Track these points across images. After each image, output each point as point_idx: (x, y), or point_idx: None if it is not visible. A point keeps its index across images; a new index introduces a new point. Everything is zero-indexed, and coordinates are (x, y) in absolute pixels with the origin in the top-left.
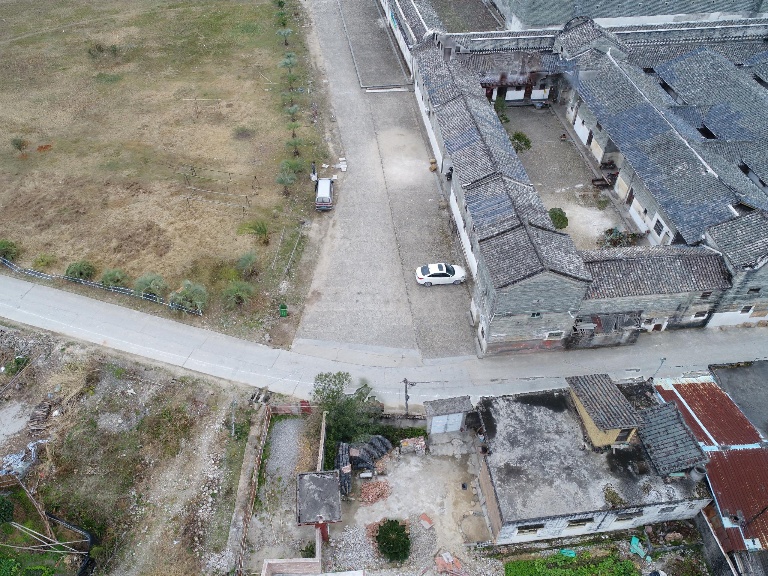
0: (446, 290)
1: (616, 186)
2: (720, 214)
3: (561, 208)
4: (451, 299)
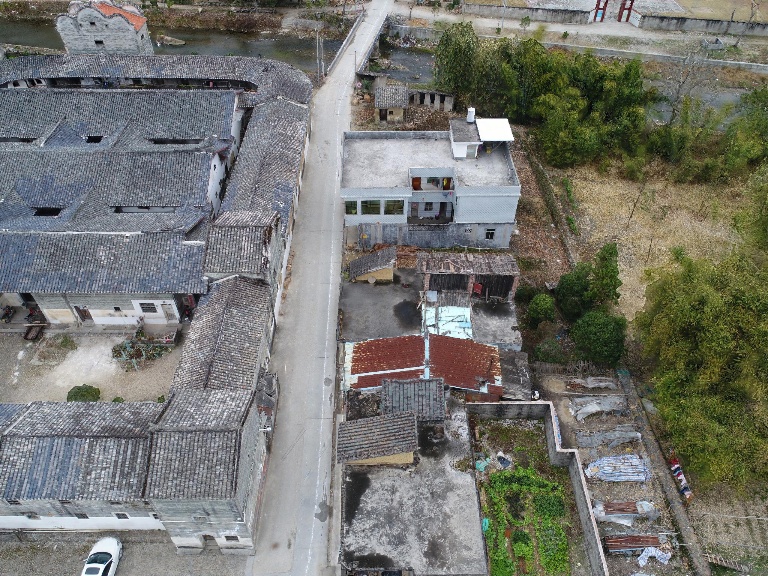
0: (125, 574)
1: (51, 320)
2: (188, 253)
3: (48, 387)
4: (144, 570)
